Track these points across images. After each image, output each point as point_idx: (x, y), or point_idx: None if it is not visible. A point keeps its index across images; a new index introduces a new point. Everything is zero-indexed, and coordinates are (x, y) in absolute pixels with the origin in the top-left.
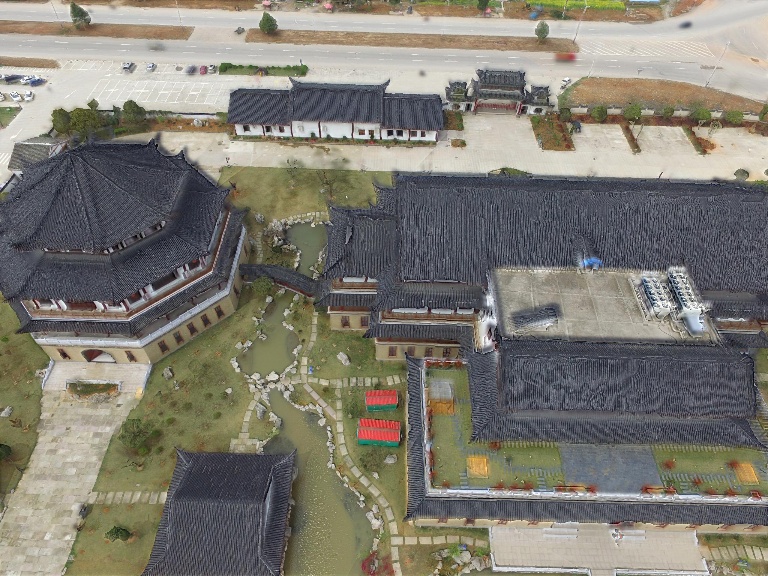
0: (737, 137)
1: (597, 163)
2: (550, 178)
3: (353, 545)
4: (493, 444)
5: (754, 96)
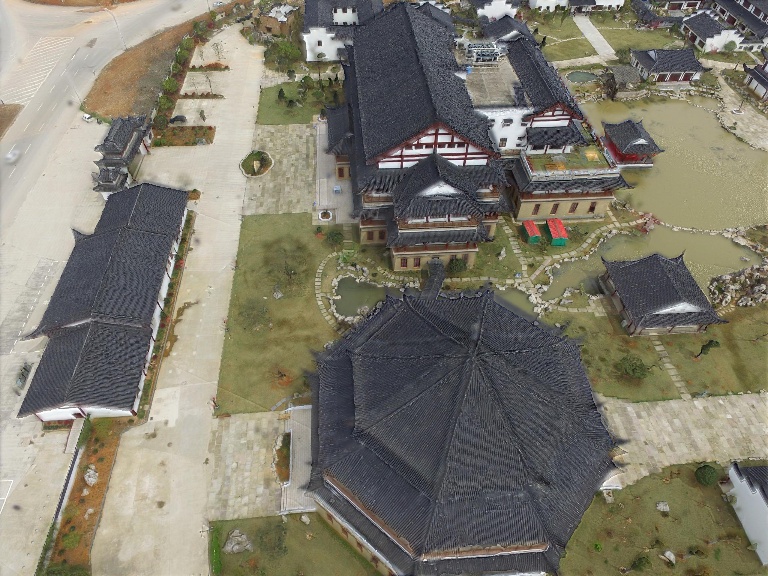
0: (207, 52)
1: (236, 117)
2: (257, 143)
3: (630, 243)
4: (574, 151)
5: (148, 34)
